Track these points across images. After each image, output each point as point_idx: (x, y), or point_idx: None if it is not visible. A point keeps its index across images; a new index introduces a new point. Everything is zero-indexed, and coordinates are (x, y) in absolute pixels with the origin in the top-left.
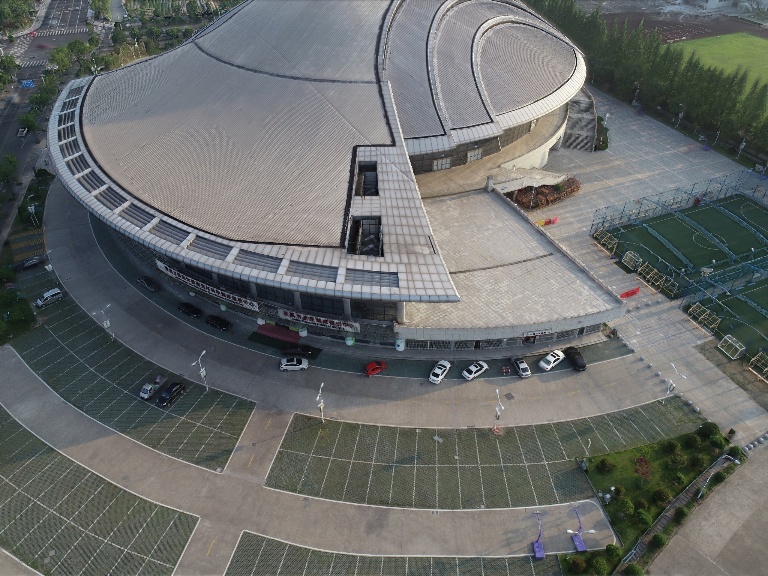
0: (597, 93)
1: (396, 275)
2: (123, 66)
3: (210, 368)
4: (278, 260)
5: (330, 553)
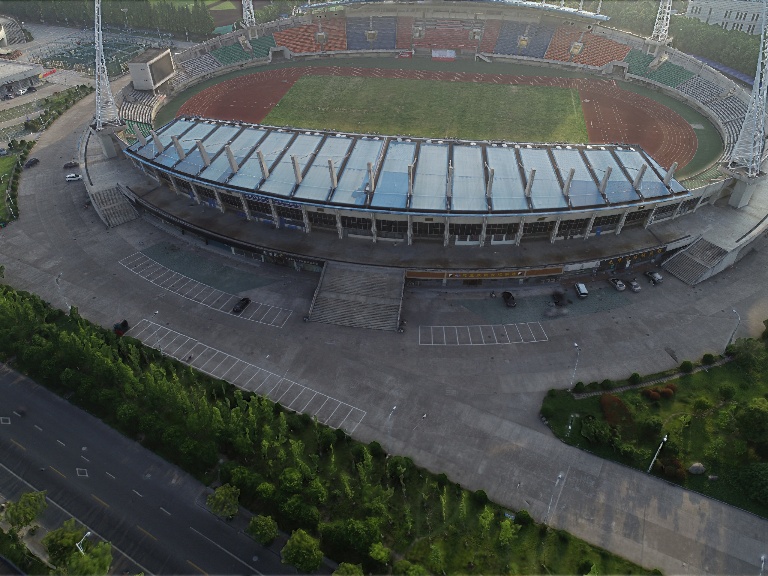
0: (23, 24)
1: None
2: None
3: None
4: None
5: None
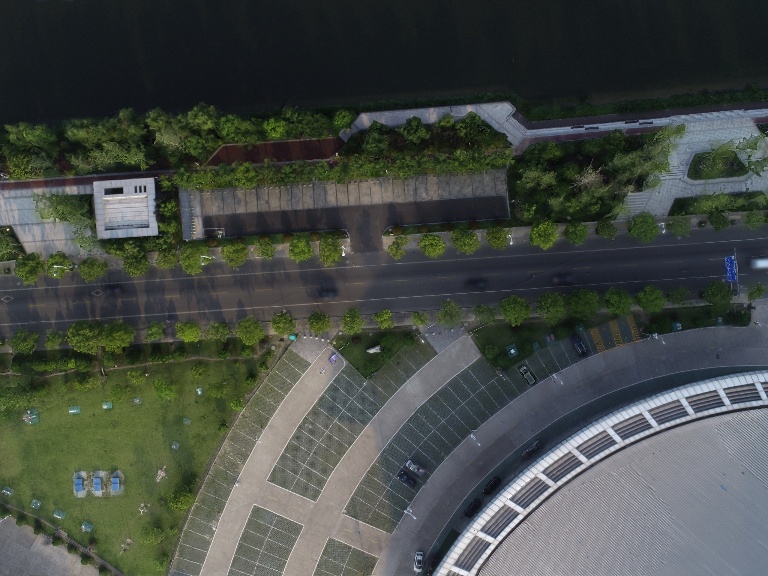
0: None
1: None
2: None
3: (429, 503)
4: None
5: (283, 570)
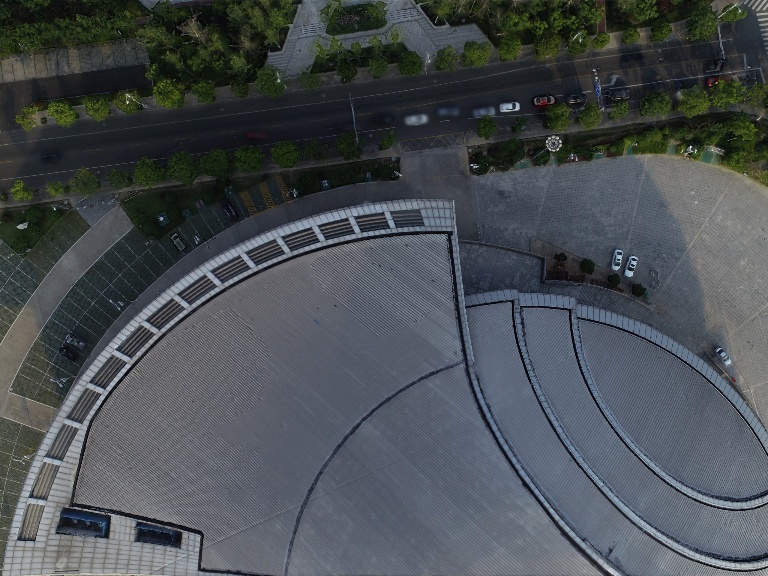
0: None
1: (34, 540)
2: (744, 175)
3: None
4: (63, 457)
5: None
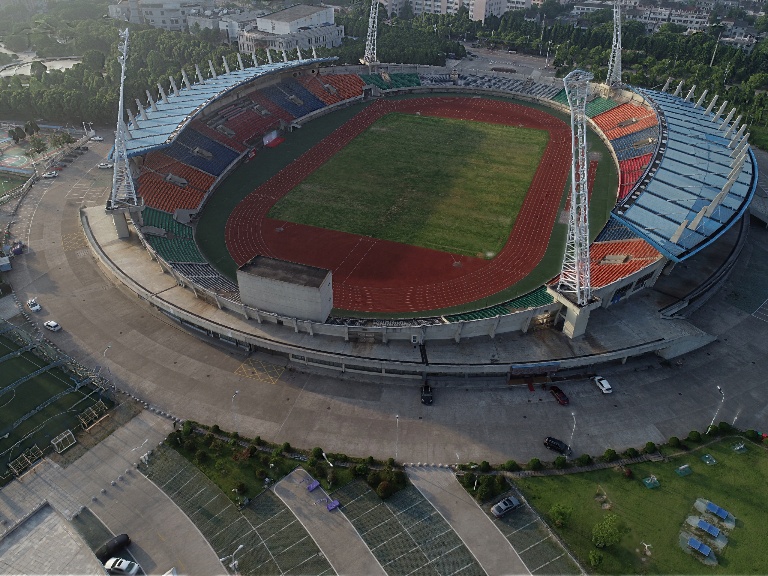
0: None
1: None
2: None
3: None
4: None
5: None
